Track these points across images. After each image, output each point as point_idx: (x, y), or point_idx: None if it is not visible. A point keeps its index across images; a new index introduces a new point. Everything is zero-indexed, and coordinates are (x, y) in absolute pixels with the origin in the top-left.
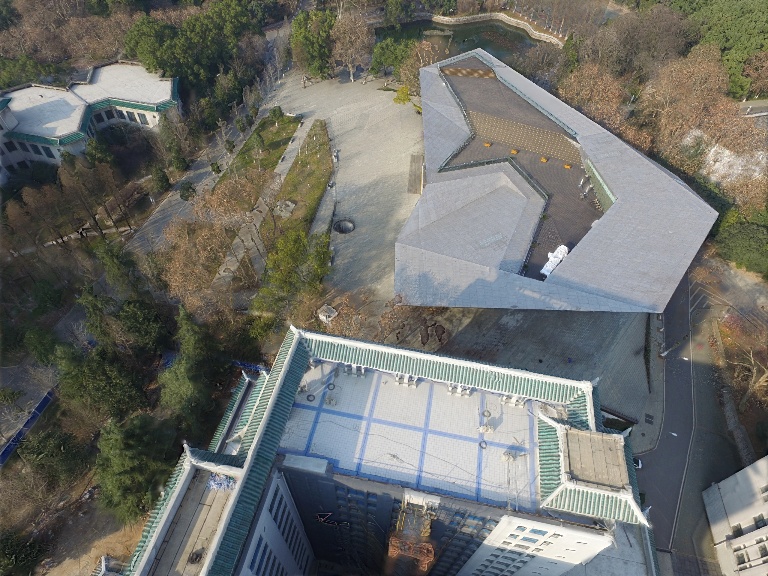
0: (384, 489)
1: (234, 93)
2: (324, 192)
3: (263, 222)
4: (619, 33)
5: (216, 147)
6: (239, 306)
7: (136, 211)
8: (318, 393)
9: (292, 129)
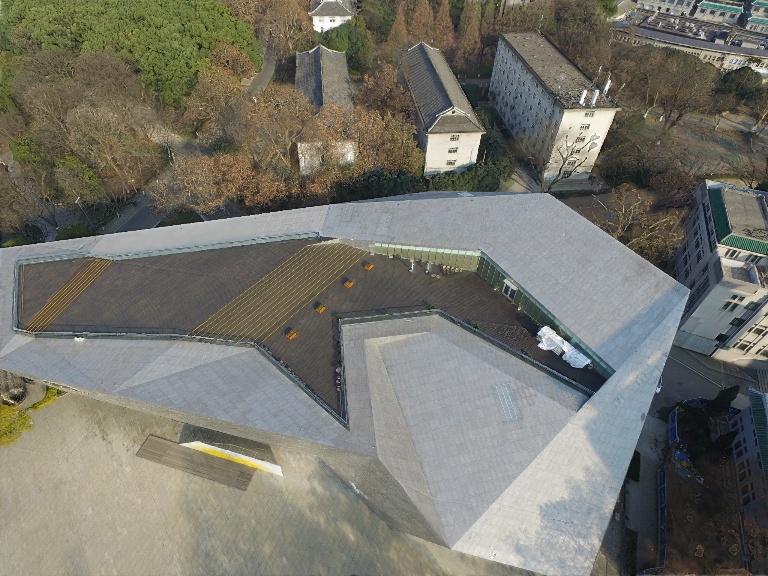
0: None
1: None
2: None
3: None
4: None
5: None
6: None
7: None
8: None
9: None
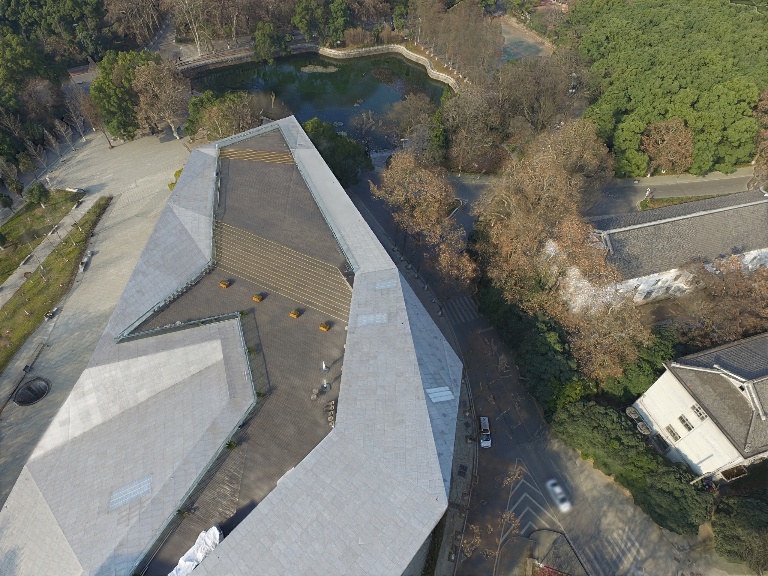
0: None
1: None
2: (37, 326)
3: None
4: (509, 83)
5: None
6: None
7: None
8: None
9: (63, 212)
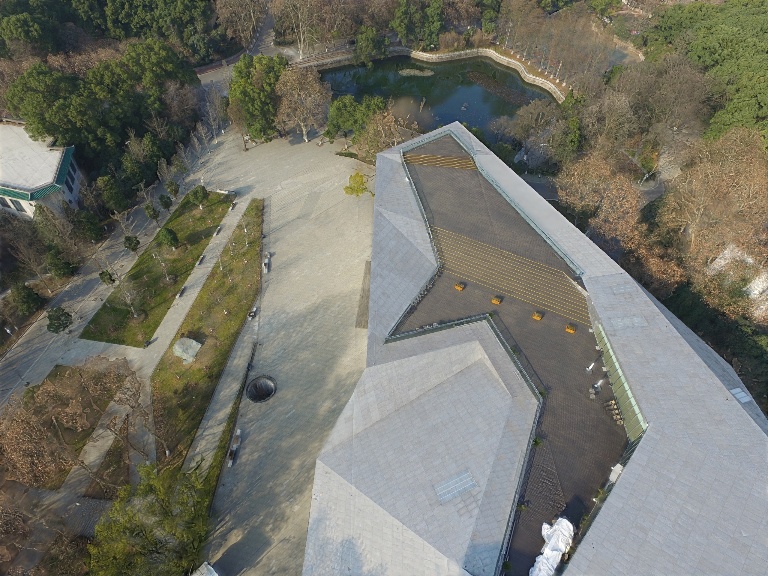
0: None
1: (151, 162)
2: (242, 325)
3: (158, 366)
4: (628, 89)
5: (120, 238)
6: (93, 531)
7: None
8: None
9: (220, 213)
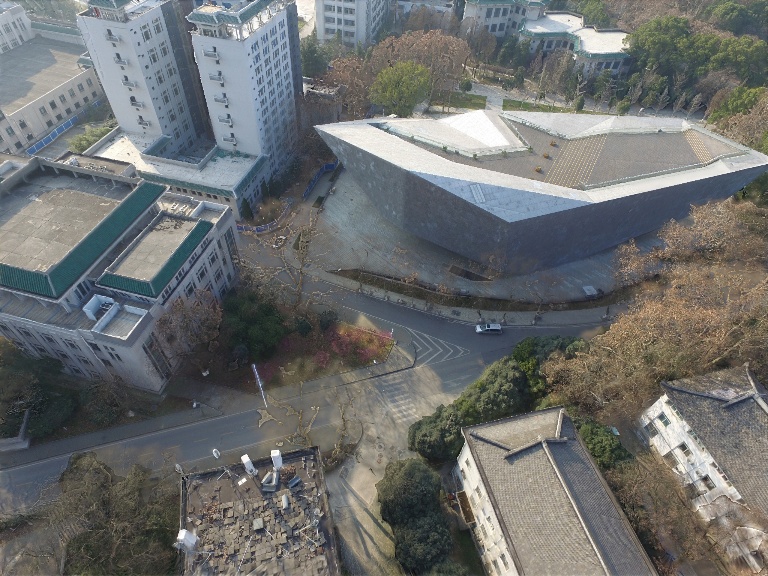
0: (230, 8)
1: (646, 91)
2: None
3: None
4: None
5: None
6: None
7: (493, 80)
8: (273, 7)
9: None
